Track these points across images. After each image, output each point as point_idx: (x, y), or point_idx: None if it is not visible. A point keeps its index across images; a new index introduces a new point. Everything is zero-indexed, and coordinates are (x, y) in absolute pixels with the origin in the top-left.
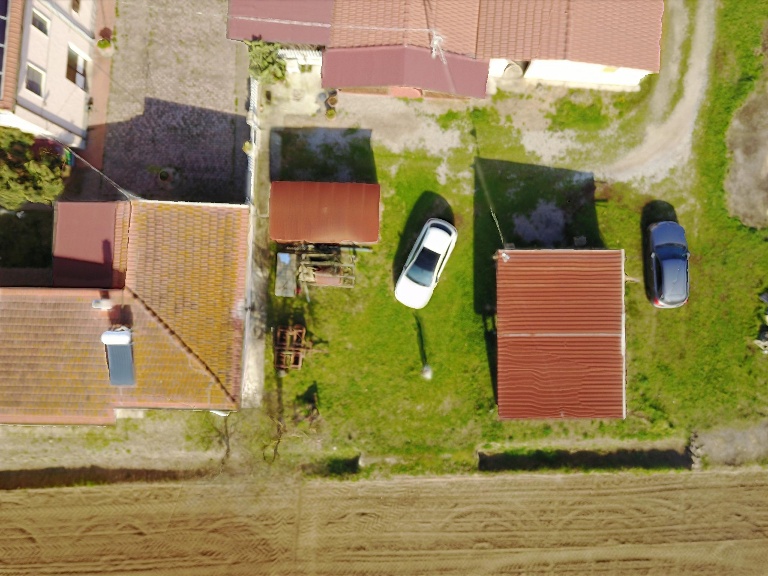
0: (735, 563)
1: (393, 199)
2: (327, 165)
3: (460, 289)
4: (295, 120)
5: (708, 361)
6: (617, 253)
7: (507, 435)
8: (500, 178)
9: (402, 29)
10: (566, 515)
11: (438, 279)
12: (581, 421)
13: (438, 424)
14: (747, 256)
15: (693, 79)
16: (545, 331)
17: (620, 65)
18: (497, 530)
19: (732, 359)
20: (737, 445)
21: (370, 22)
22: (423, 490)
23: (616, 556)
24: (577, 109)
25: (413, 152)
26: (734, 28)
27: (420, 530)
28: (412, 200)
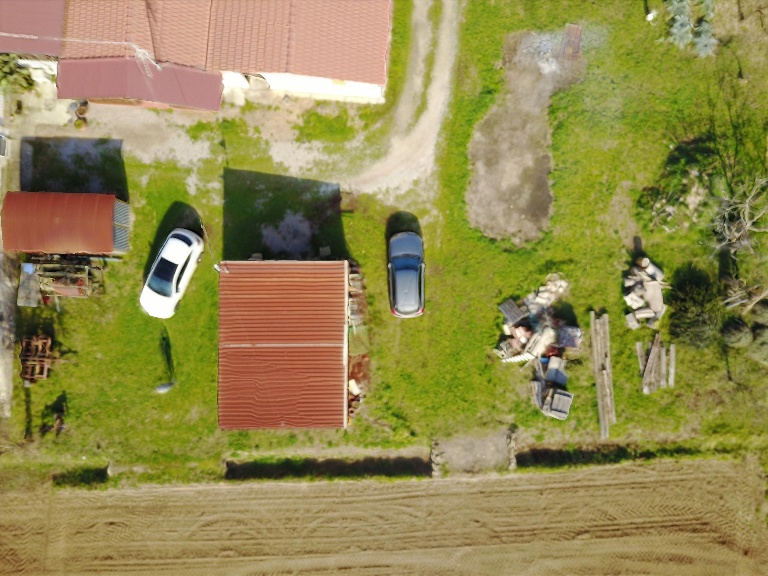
0: (473, 569)
1: (144, 209)
2: (78, 175)
3: (209, 299)
4: (46, 130)
5: (450, 370)
6: (341, 264)
7: (253, 444)
8: (249, 188)
9: (103, 42)
10: (311, 523)
11: (185, 289)
12: (326, 429)
13: (185, 433)
14: (487, 266)
15: (436, 92)
16: (265, 341)
17: (344, 78)
18: (242, 538)
19: (473, 368)
20: (476, 452)
21: (97, 33)
22: (171, 499)
23: (358, 563)
24: (323, 120)
25: (163, 162)
26: (475, 42)
27: (167, 539)
28: (162, 210)
